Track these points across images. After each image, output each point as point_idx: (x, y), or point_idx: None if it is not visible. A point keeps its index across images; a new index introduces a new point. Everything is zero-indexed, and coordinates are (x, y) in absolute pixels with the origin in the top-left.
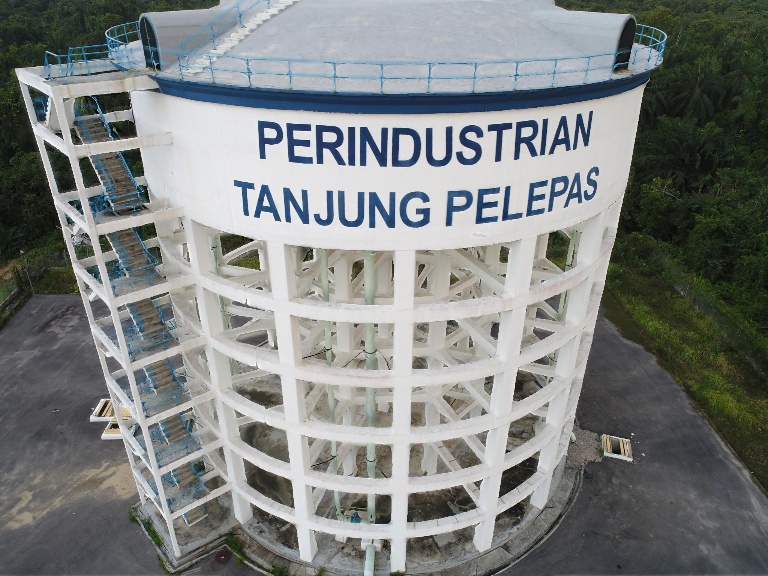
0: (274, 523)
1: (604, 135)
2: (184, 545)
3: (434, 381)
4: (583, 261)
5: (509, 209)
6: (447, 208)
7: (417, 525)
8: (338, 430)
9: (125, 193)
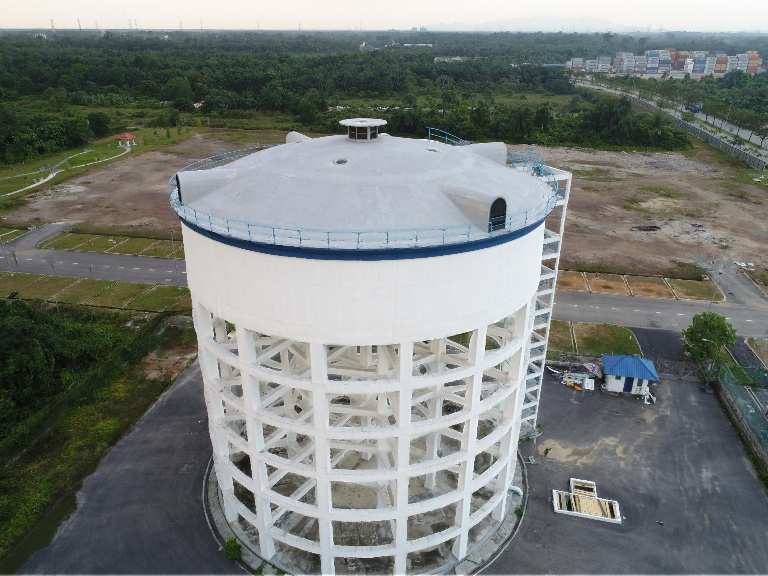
0: (453, 406)
1: None
2: None
3: None
4: None
5: None
6: None
7: None
8: None
9: None
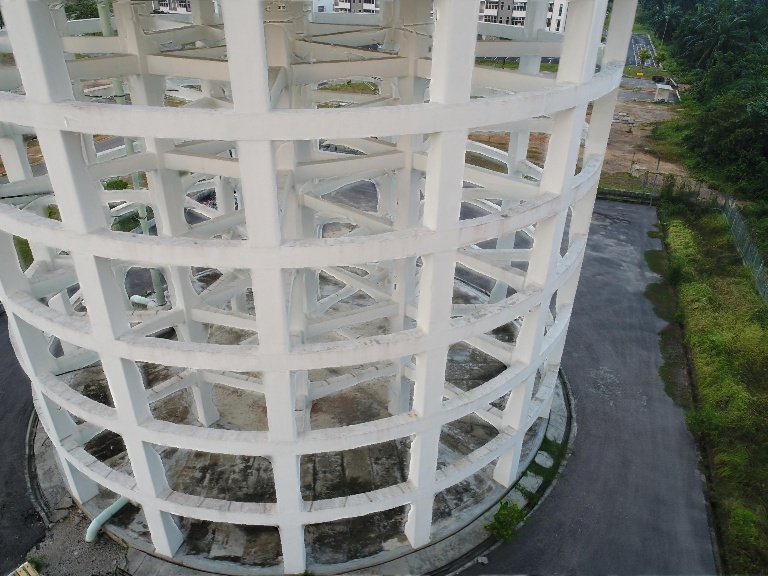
0: None
1: None
2: None
3: None
4: None
5: None
6: None
7: None
8: None
9: None
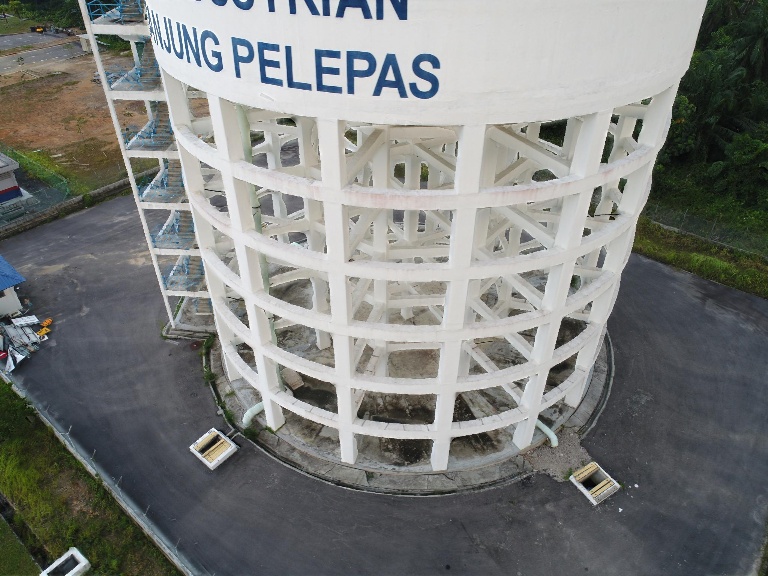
0: None
1: (443, 12)
2: (181, 323)
3: (260, 248)
4: (456, 188)
5: (294, 75)
6: (234, 56)
7: (280, 393)
8: (216, 265)
9: (134, 7)
